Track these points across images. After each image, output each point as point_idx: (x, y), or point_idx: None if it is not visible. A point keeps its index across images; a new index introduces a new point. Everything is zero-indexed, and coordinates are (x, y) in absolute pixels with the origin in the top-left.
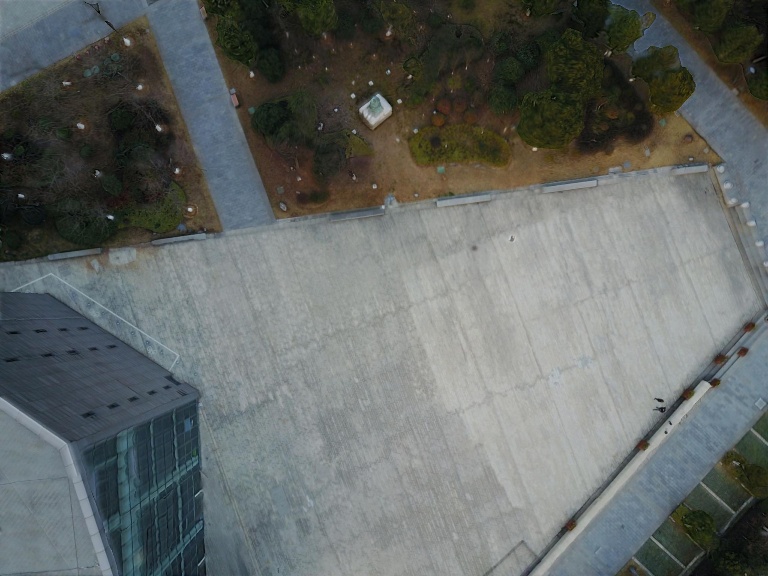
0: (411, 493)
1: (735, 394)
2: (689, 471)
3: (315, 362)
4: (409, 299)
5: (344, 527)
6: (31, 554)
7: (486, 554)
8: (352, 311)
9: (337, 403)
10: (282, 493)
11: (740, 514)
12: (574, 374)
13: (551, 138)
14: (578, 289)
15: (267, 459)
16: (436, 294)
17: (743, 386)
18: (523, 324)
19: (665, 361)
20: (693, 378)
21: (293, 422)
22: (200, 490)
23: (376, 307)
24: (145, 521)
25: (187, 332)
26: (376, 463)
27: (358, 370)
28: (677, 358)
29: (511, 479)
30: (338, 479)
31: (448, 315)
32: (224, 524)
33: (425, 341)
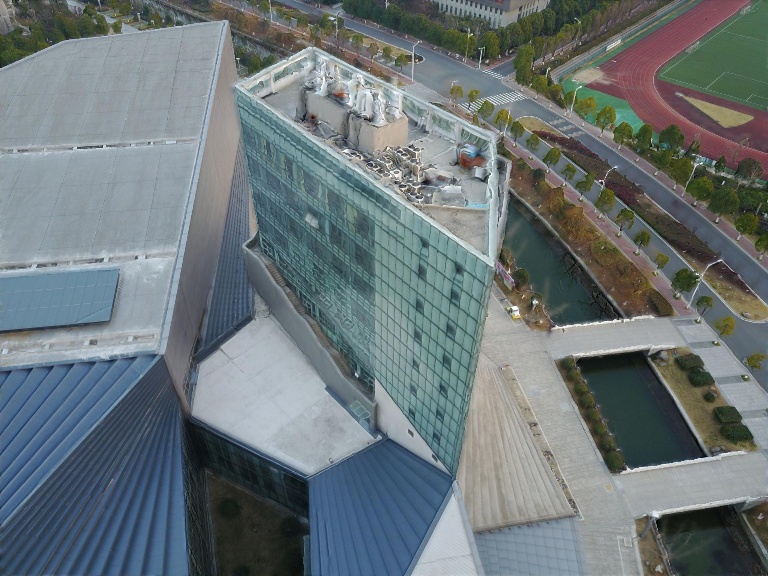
0: None
1: None
2: None
3: None
4: None
5: None
6: None
7: None
8: None
9: None
10: None
11: None
12: None
13: None
14: None
15: None
16: None
17: None
18: None
19: None
20: None
21: None
22: None
23: None
24: None
25: None
26: None
27: None
28: None
29: None
30: None
31: None
32: None
33: None
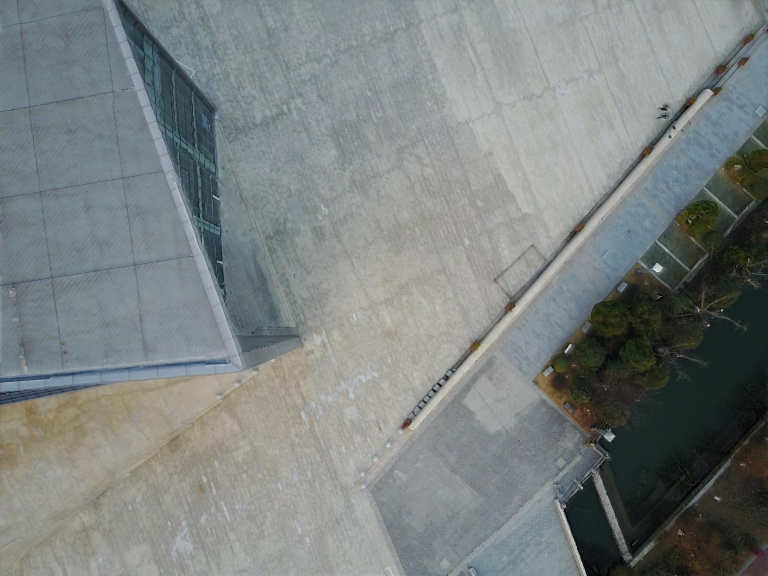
0: (423, 201)
1: (736, 102)
2: (692, 177)
3: (328, 76)
4: (419, 15)
5: (358, 234)
6: (67, 83)
7: (497, 258)
8: (364, 28)
9: (350, 115)
10: (297, 202)
11: (742, 217)
12: (580, 85)
13: None
14: (583, 4)
15: (282, 170)
16: (445, 10)
17: (744, 94)
18: (530, 38)
19: (668, 72)
20: (695, 88)
21: (307, 134)
22: (217, 198)
23: (387, 23)
24: (170, 149)
25: (202, 49)
26: (389, 172)
27: (370, 84)
28: (680, 69)
29: (520, 186)
30: (352, 188)
31: (457, 30)
32: (241, 231)
33: (435, 55)
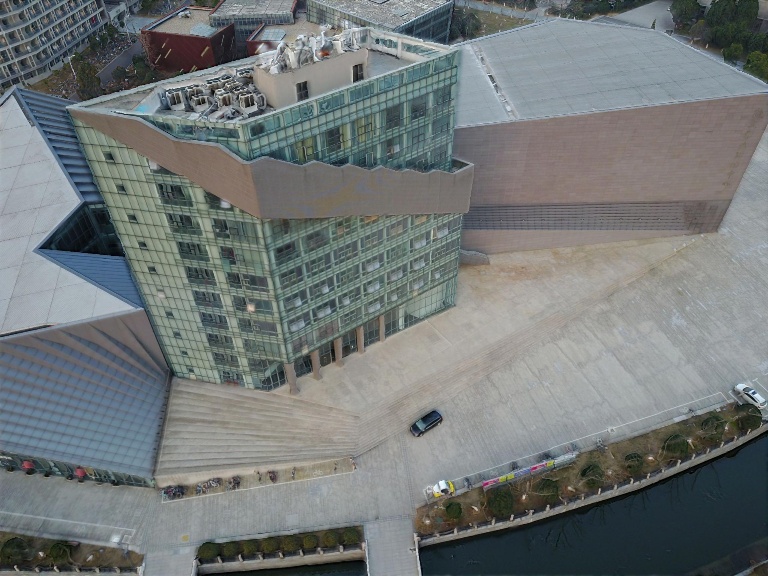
0: None
1: None
2: None
3: None
4: None
5: None
6: None
7: None
8: None
9: None
10: None
11: None
12: None
13: (762, 74)
14: None
15: None
16: None
17: None
18: None
19: None
20: None
21: None
22: None
23: None
24: None
25: None
26: None
27: None
28: None
29: None
30: None
31: None
32: None
33: None
